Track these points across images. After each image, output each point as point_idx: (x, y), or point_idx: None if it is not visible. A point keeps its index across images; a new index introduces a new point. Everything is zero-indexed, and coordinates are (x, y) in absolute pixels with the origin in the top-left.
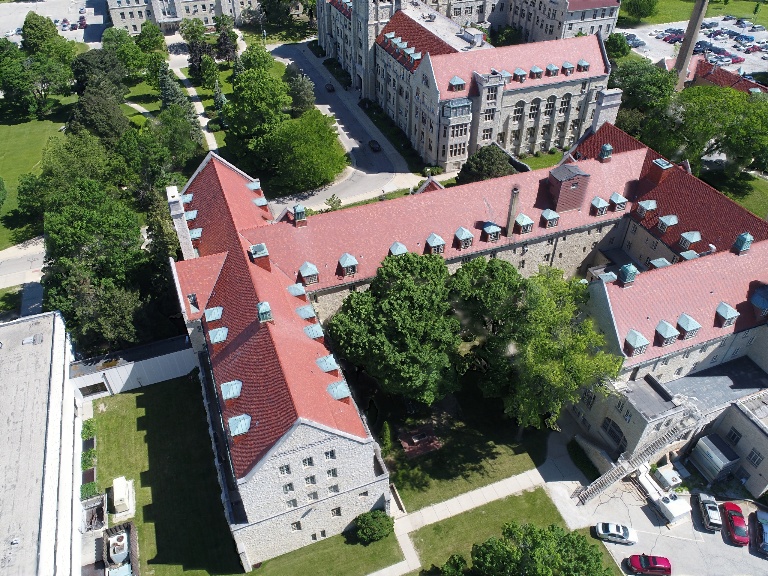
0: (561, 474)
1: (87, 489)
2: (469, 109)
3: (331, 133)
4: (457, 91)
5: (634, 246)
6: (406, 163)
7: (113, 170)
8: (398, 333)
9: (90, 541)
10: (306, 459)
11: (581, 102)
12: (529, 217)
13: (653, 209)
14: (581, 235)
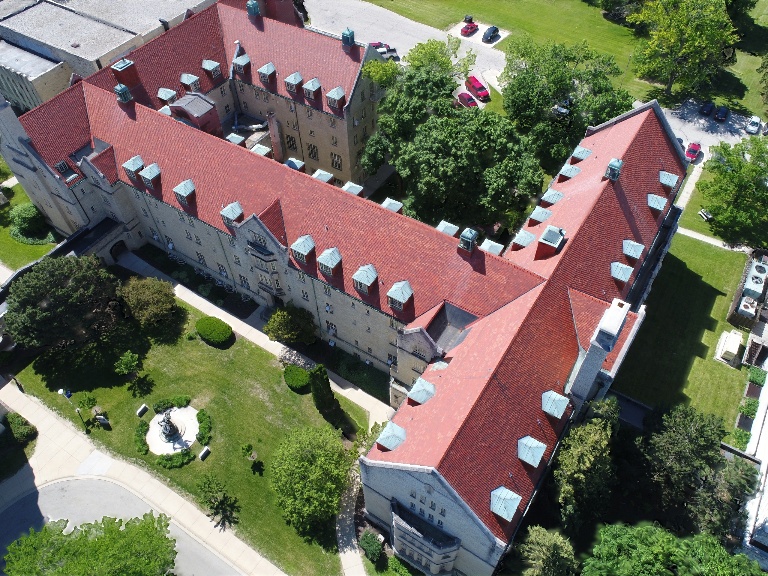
0: None
1: (759, 376)
2: None
3: None
4: None
5: None
6: None
7: None
8: None
9: (766, 339)
10: None
11: None
12: None
13: None
14: None
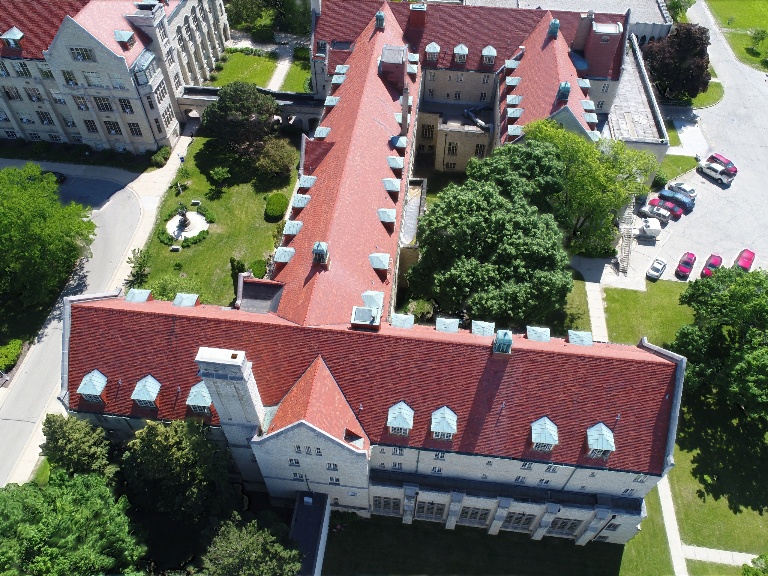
0: (596, 270)
1: None
2: (156, 62)
3: None
4: (132, 47)
5: (438, 91)
6: (118, 169)
7: None
8: (537, 261)
9: None
10: None
11: (208, 2)
12: None
13: (439, 50)
14: None
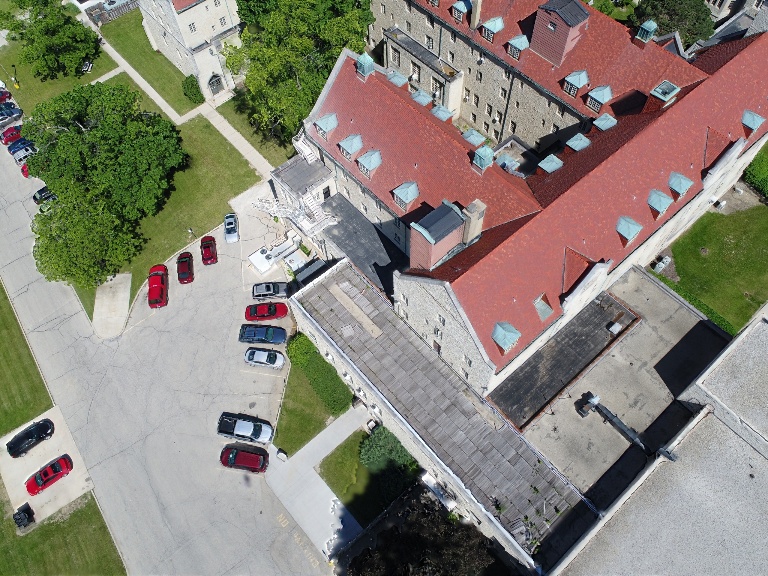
0: None
1: None
2: None
3: None
4: None
5: None
6: None
7: None
8: None
9: None
10: None
11: None
12: (504, 28)
13: (601, 129)
14: (540, 98)
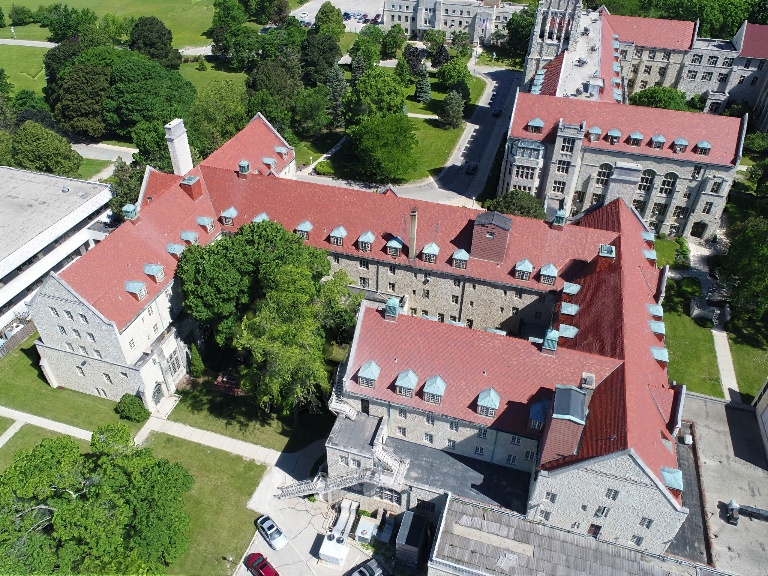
0: (293, 468)
1: None
2: (539, 154)
3: (408, 138)
4: (532, 132)
5: None
6: (481, 191)
7: (239, 116)
8: None
9: None
10: (68, 312)
11: (692, 189)
12: (440, 249)
13: (572, 294)
14: (495, 291)
